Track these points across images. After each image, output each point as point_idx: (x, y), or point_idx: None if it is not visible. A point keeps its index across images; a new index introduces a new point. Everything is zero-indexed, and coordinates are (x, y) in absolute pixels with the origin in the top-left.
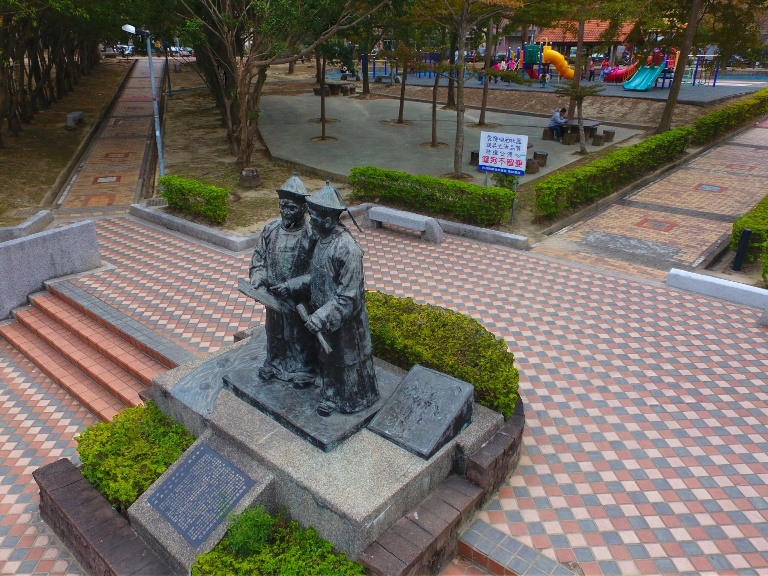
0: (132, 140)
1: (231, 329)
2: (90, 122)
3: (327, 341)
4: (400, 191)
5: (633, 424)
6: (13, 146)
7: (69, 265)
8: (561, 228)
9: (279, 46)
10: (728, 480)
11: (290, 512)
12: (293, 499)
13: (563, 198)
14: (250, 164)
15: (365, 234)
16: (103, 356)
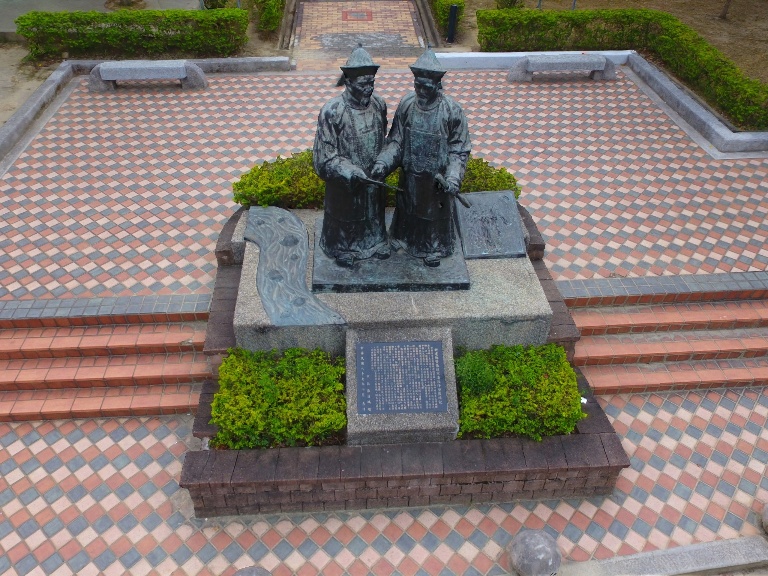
0: None
1: (149, 254)
2: None
3: (437, 200)
4: (101, 36)
5: (535, 180)
6: None
7: None
8: (283, 39)
9: None
10: (610, 189)
11: (466, 347)
12: (473, 335)
13: (279, 7)
14: None
15: (113, 100)
16: (11, 360)
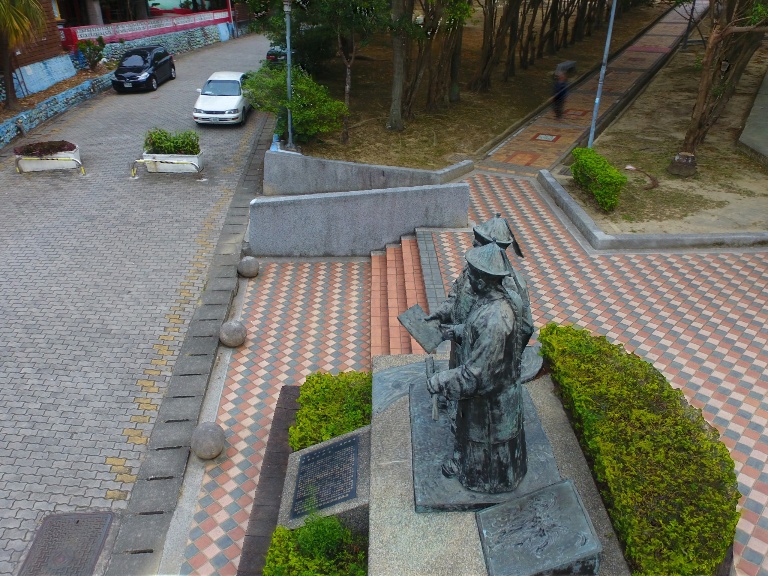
0: (603, 97)
1: None
2: (581, 72)
3: (460, 405)
4: None
5: None
6: (496, 91)
7: (439, 219)
8: None
9: (765, 10)
10: None
11: None
12: None
13: None
14: (705, 145)
15: None
16: None
